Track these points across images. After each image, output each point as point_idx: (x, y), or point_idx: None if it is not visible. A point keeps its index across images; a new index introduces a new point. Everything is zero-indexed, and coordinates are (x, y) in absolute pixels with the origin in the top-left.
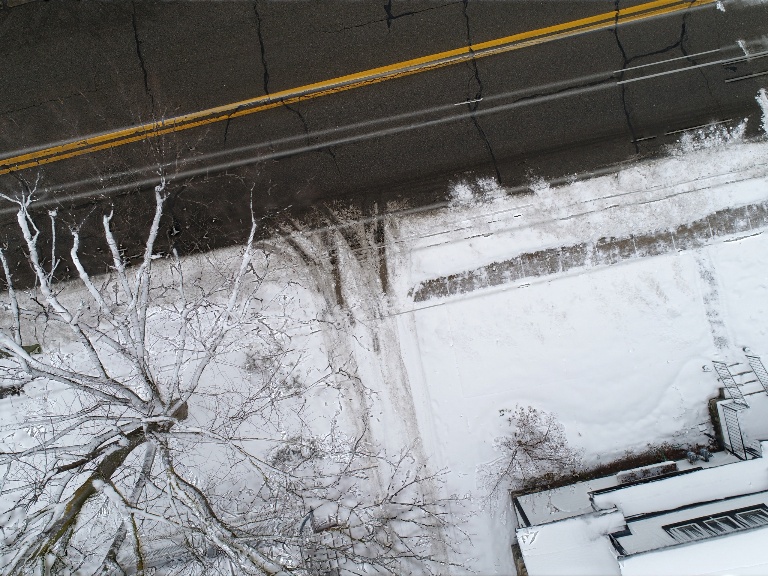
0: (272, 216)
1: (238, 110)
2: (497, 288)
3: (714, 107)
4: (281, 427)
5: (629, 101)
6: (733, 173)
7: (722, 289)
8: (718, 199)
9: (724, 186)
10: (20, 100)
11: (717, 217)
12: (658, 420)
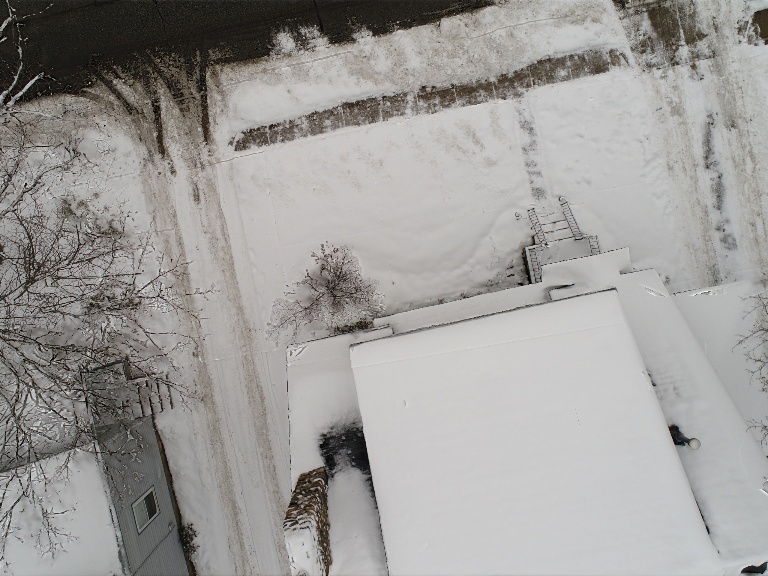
0: (95, 63)
1: None
2: (317, 137)
3: None
4: (98, 274)
5: None
6: (552, 19)
7: (540, 139)
8: (536, 46)
9: (542, 32)
10: None
11: (538, 67)
12: (473, 270)
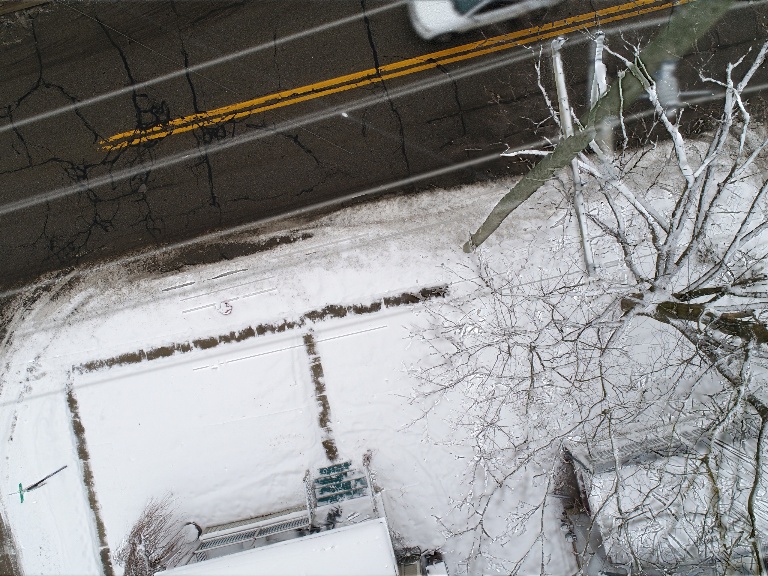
0: (715, 107)
1: None
2: None
3: None
4: None
5: None
6: None
7: None
8: None
9: None
10: None
11: None
12: None
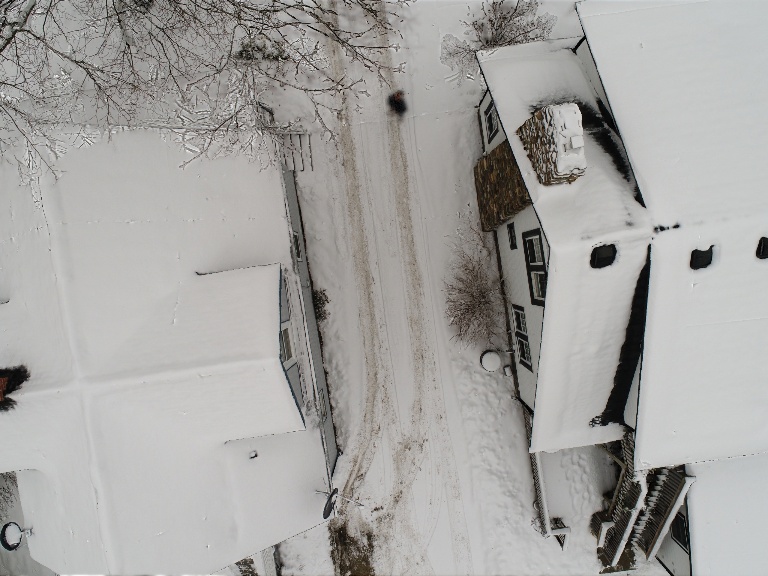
0: None
1: None
2: None
3: None
4: None
5: None
6: None
7: None
8: None
9: None
10: None
11: None
12: None
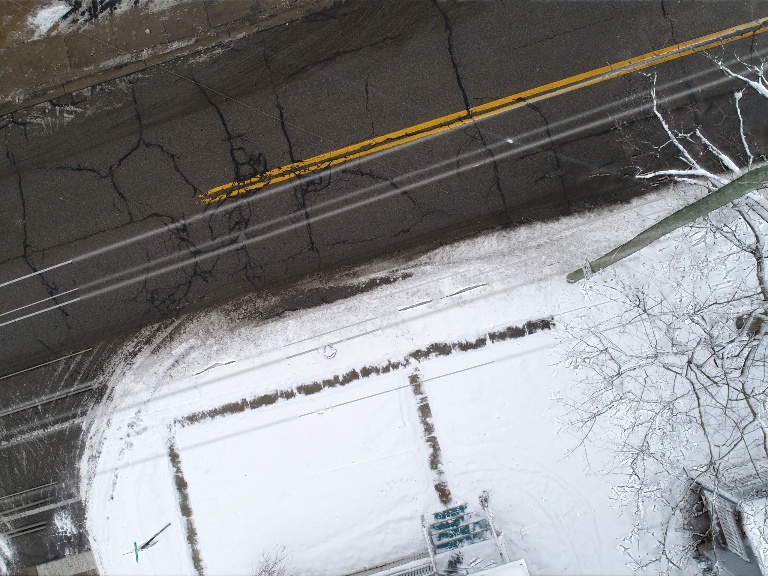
0: None
1: None
2: None
3: None
4: None
5: None
6: None
7: None
8: None
9: None
10: (533, 34)
11: None
12: None
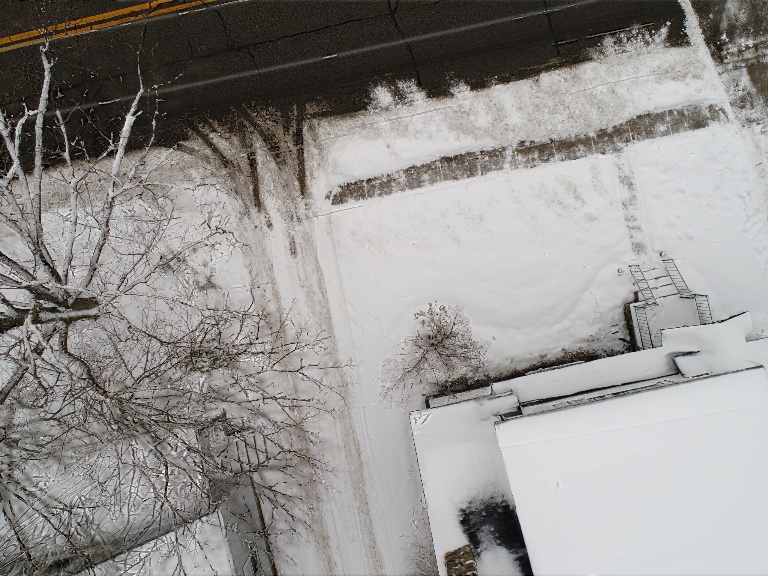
0: (191, 117)
1: (157, 9)
2: (415, 191)
3: (636, 10)
4: None
5: (551, 3)
6: (653, 75)
7: (640, 194)
8: (637, 102)
9: (643, 88)
10: None
11: (637, 122)
12: (573, 325)
